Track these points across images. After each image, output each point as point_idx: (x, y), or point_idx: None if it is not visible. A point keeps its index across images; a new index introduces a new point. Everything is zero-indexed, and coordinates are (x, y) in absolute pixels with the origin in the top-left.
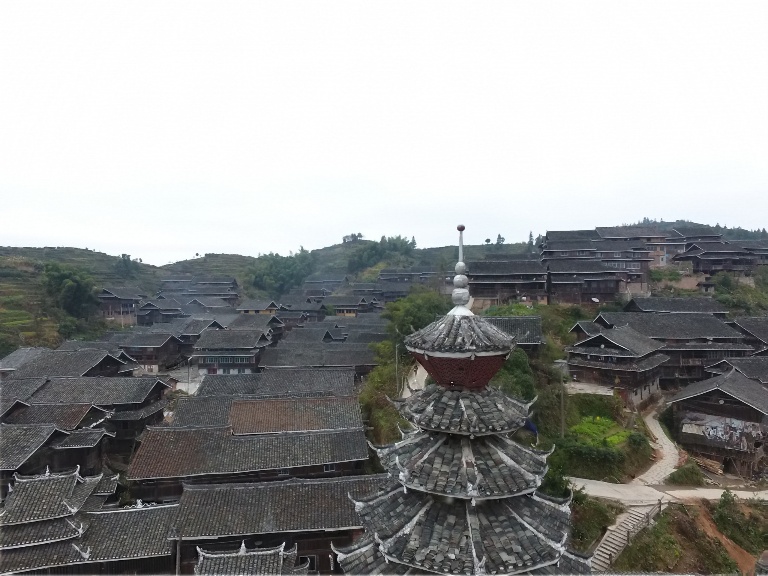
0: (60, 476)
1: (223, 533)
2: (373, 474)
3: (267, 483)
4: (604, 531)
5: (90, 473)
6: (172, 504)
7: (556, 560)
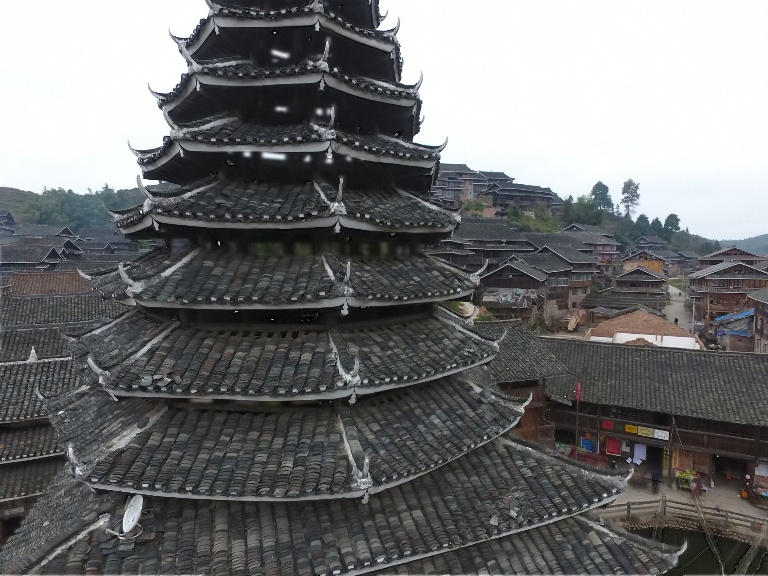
0: None
1: None
2: None
3: (65, 323)
4: None
5: None
6: None
7: (390, 48)
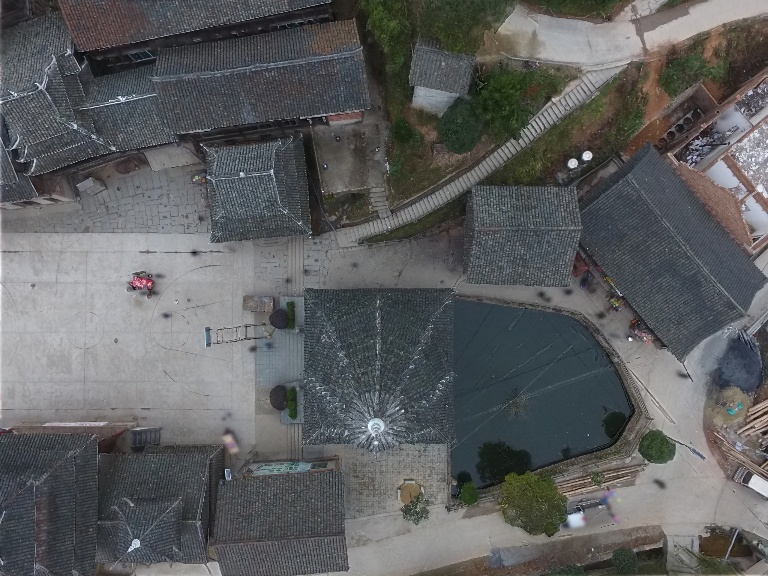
0: (28, 93)
1: (213, 127)
2: (338, 53)
3: (231, 71)
4: (547, 101)
5: (15, 1)
6: (150, 94)
7: None
